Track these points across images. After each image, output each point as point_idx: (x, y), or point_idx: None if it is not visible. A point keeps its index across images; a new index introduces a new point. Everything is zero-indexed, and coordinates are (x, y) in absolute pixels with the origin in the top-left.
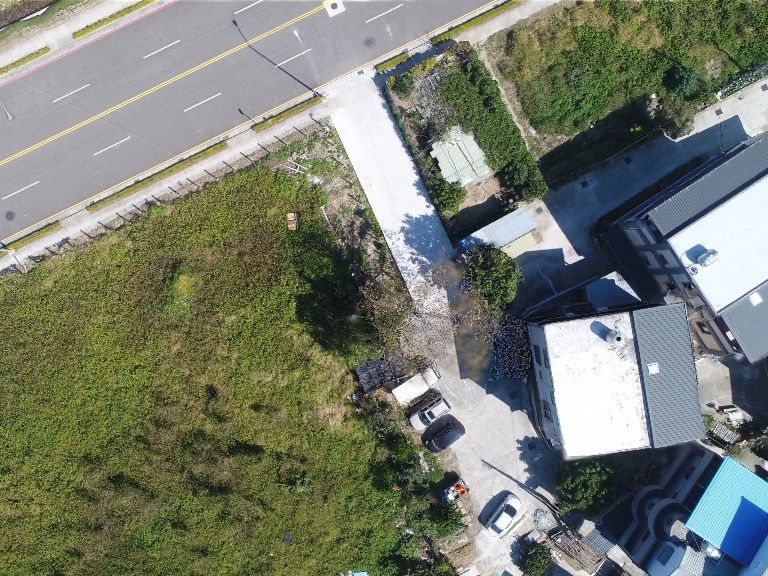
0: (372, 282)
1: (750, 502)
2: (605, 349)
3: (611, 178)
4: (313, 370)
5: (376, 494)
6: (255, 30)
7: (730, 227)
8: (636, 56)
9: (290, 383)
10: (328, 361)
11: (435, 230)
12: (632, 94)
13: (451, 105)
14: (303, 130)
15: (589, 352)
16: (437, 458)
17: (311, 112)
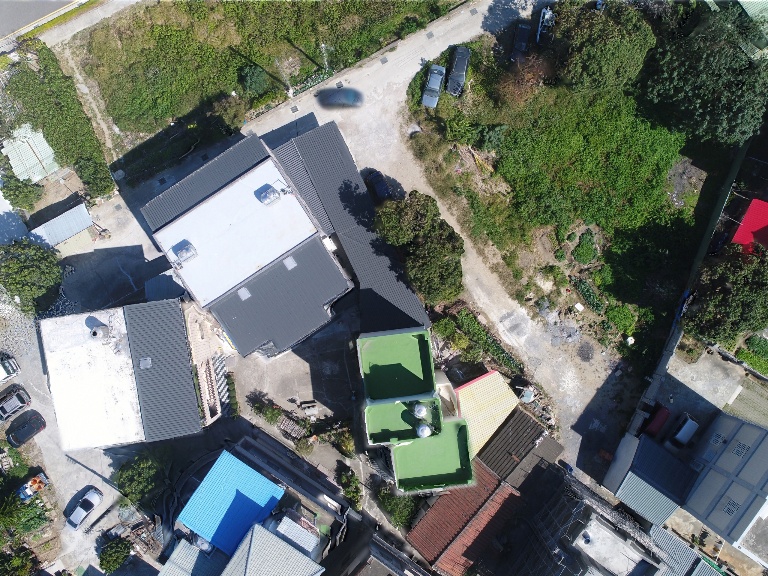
0: None
1: (245, 496)
2: (100, 344)
3: None
4: None
5: None
6: None
7: (215, 223)
8: (210, 54)
9: None
10: None
11: (17, 227)
12: (207, 92)
13: (21, 103)
14: None
15: (84, 347)
16: (22, 453)
17: None
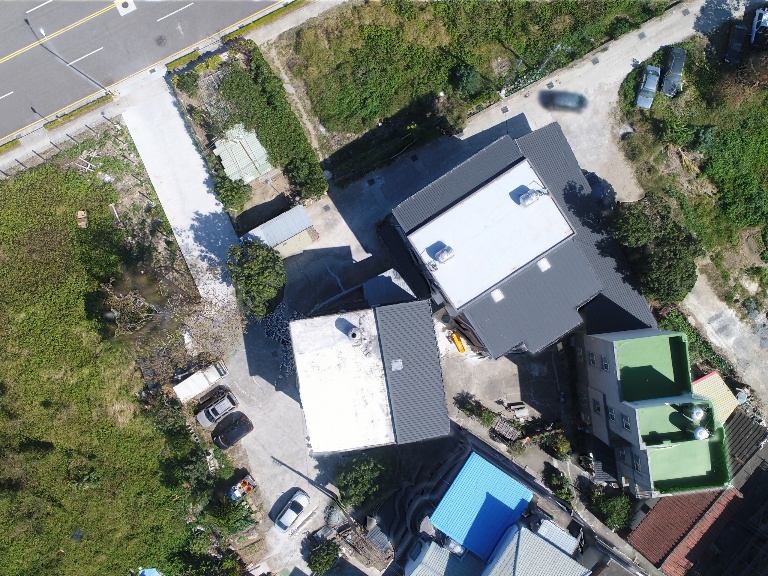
0: (161, 279)
1: (495, 498)
2: (350, 346)
3: (398, 176)
4: (102, 367)
5: (165, 491)
6: (47, 29)
7: (470, 224)
8: (421, 54)
9: (80, 380)
10: (117, 358)
11: (224, 228)
12: (418, 92)
13: (233, 103)
14: (95, 128)
15: (334, 349)
16: (227, 455)
17: (103, 110)
